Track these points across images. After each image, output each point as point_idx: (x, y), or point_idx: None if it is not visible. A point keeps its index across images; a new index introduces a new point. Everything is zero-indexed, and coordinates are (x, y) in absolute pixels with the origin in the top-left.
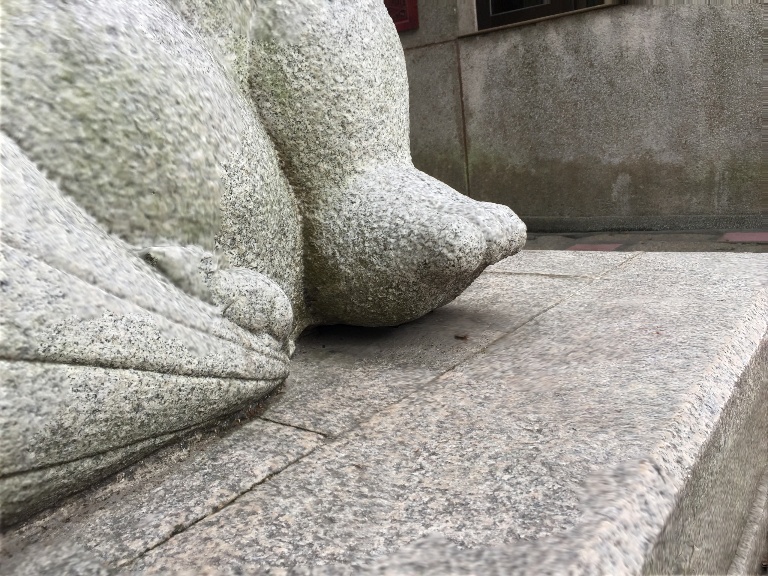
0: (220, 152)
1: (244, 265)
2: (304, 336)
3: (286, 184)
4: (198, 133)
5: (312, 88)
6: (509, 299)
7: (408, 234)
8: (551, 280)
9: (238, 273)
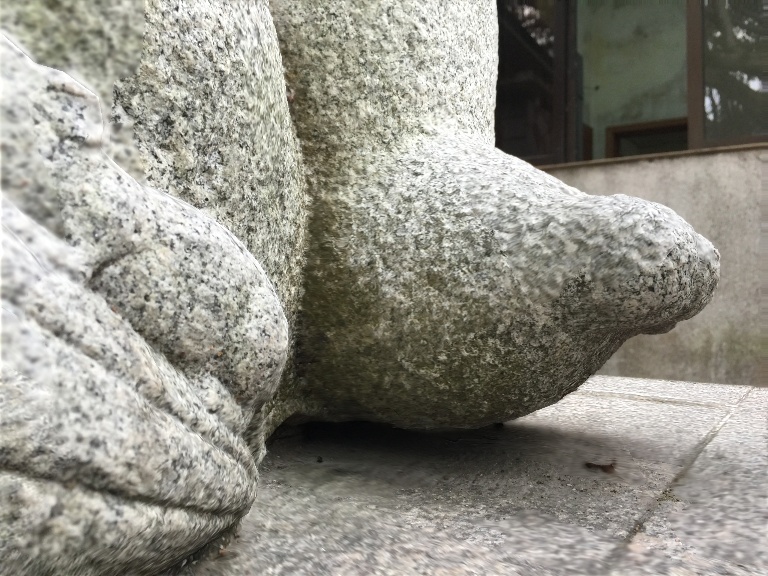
0: None
1: None
2: (281, 437)
3: (292, 130)
4: None
5: None
6: (622, 419)
7: (543, 222)
8: (661, 403)
9: (163, 193)
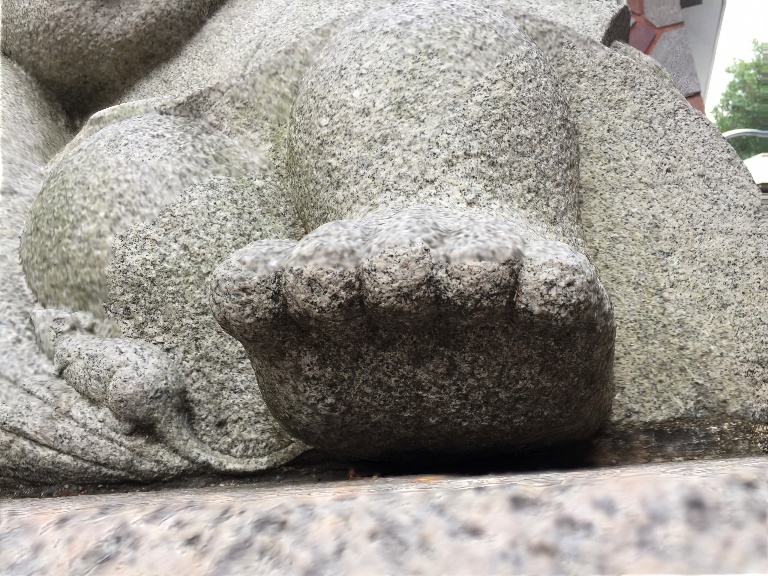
0: (121, 224)
1: (144, 338)
2: (335, 469)
3: None
4: (98, 210)
5: (304, 145)
6: None
7: None
8: None
9: (103, 339)
